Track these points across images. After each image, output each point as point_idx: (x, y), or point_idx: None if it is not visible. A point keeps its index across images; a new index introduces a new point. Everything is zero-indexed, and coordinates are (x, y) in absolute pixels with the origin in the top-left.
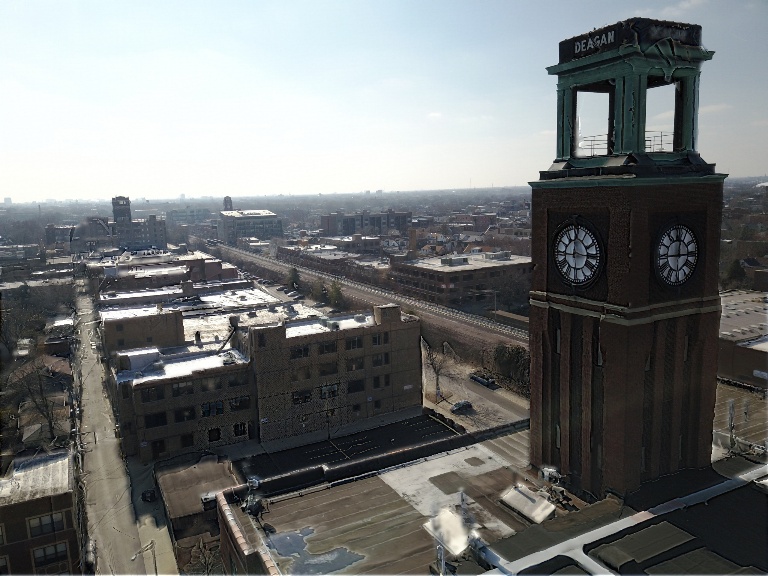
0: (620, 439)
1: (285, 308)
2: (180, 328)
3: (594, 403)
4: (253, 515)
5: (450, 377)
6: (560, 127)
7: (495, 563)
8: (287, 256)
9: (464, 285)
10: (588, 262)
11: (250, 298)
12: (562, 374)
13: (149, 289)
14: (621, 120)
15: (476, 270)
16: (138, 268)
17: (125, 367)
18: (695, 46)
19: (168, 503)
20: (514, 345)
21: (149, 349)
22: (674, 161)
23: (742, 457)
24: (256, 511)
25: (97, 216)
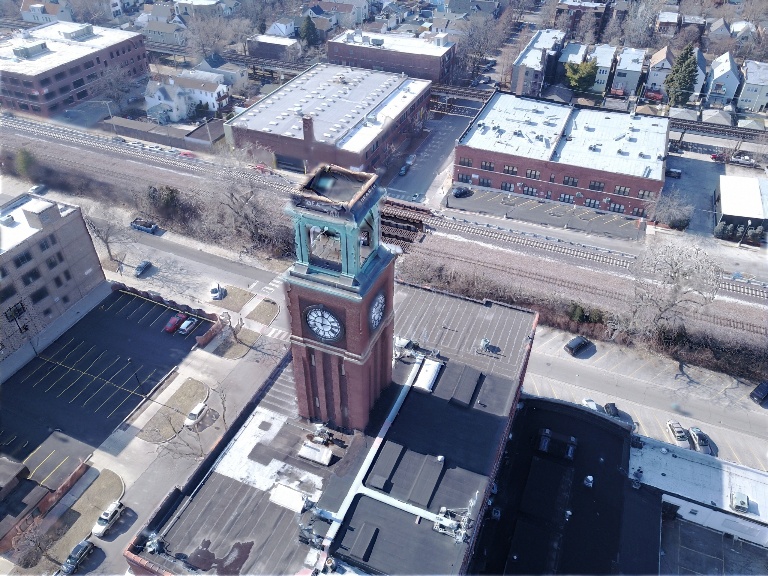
0: (360, 409)
1: None
2: None
3: (341, 391)
4: (162, 553)
5: (121, 243)
6: None
7: (331, 518)
8: None
9: (59, 86)
10: (333, 331)
11: None
12: (318, 377)
13: None
14: (346, 257)
15: (67, 64)
16: None
17: None
18: (380, 199)
19: None
20: (167, 190)
21: None
22: (372, 261)
23: (401, 362)
24: (160, 548)
25: None
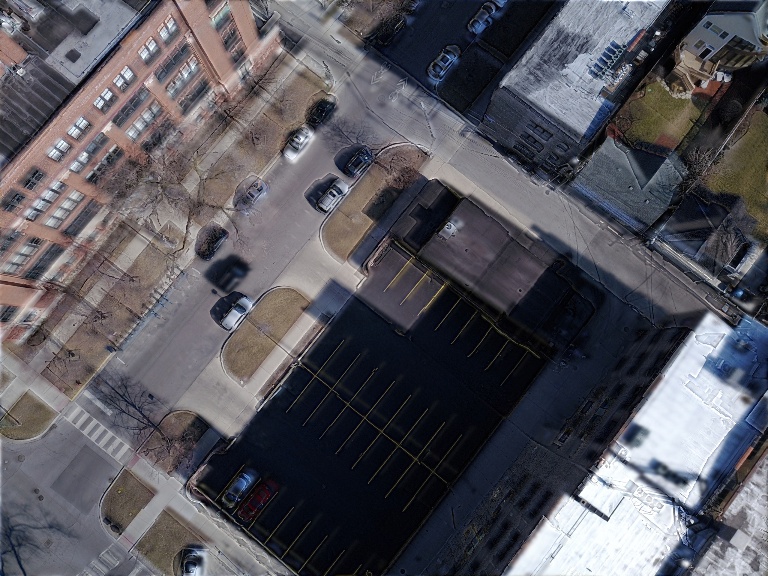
0: None
1: None
2: None
3: None
4: None
5: None
6: None
7: None
8: None
9: None
10: None
11: None
12: None
13: None
14: None
15: None
16: None
17: (761, 370)
18: None
19: (490, 218)
20: None
21: None
22: None
23: None
24: None
25: None
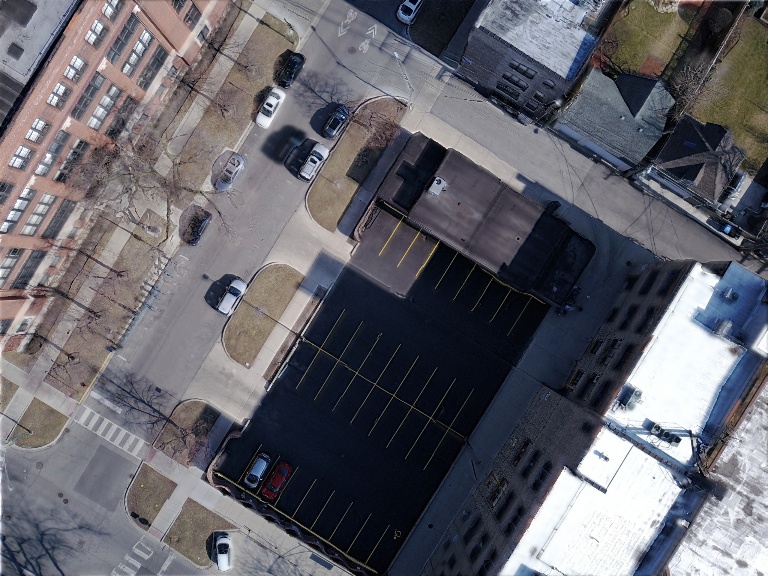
0: None
1: None
2: None
3: None
4: None
5: None
6: None
7: None
8: None
9: None
10: None
11: None
12: None
13: None
14: None
15: None
16: None
17: None
18: None
19: (480, 167)
20: None
21: None
22: None
23: None
24: None
25: None
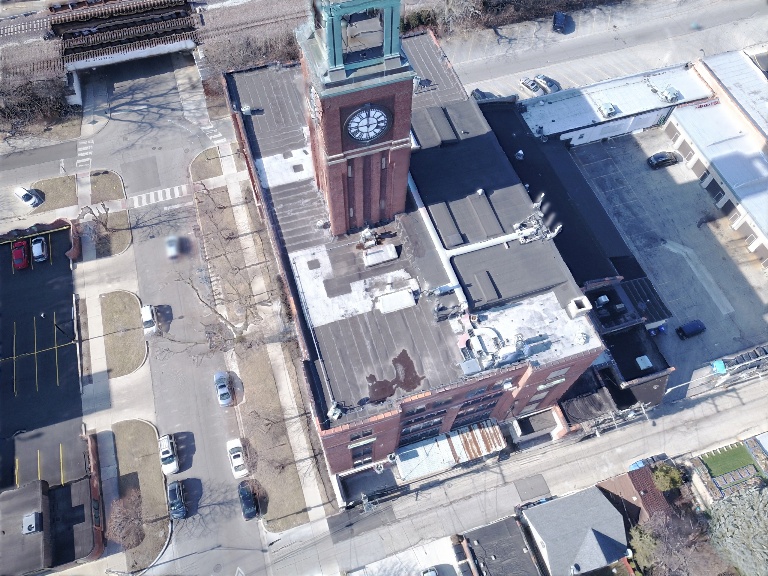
0: (403, 192)
1: None
2: None
3: (381, 186)
4: (346, 411)
5: None
6: (332, 46)
7: (450, 289)
8: None
9: None
10: None
11: None
12: None
13: None
14: (390, 35)
15: None
16: None
17: None
18: None
19: None
20: None
21: None
22: None
23: None
24: (342, 410)
25: None
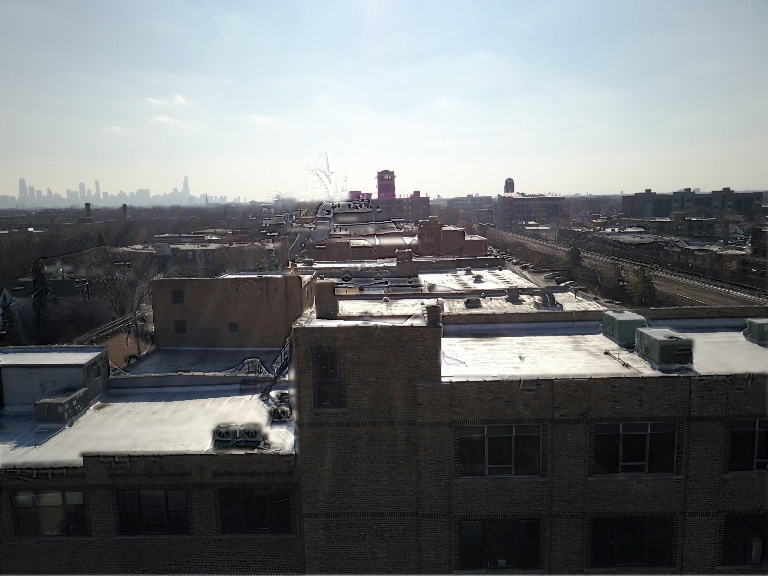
0: None
1: (535, 295)
2: (294, 310)
3: None
4: None
5: None
6: None
7: None
8: (570, 240)
9: None
10: None
11: (490, 280)
12: None
13: (358, 260)
14: None
15: None
16: (342, 228)
17: None
18: None
19: None
20: None
21: (80, 351)
22: None
23: None
24: None
25: (318, 167)
